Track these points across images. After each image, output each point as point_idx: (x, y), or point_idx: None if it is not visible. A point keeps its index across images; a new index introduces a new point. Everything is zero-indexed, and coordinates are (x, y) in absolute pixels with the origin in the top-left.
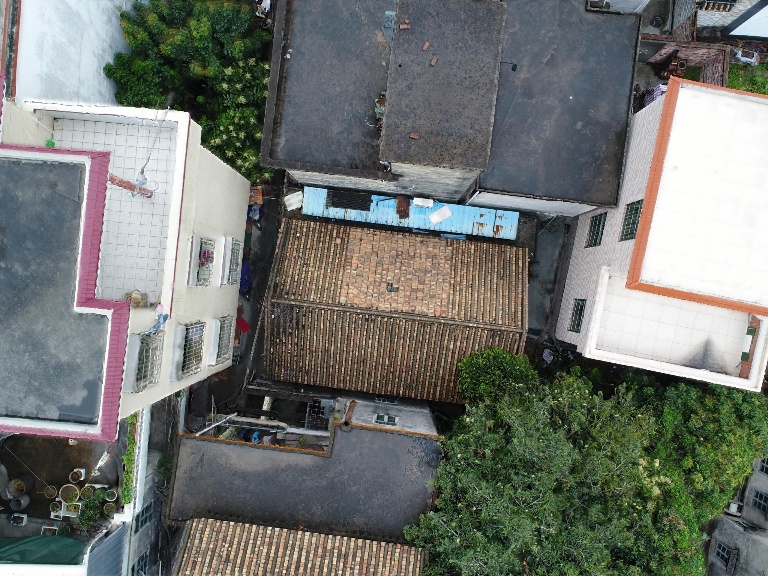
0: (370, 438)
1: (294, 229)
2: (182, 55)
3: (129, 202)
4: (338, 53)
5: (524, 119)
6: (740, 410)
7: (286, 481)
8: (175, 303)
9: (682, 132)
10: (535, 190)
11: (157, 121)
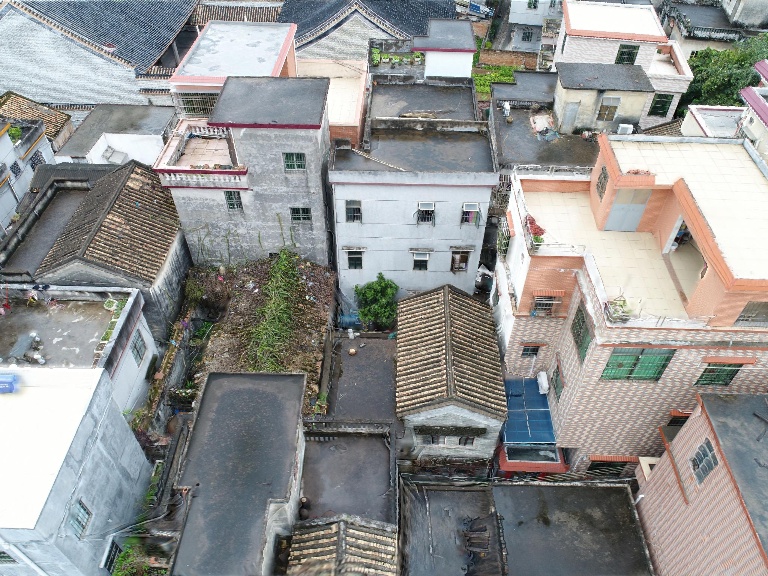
0: None
1: None
2: None
3: None
4: (569, 156)
5: None
6: None
7: None
8: None
9: None
10: None
11: None
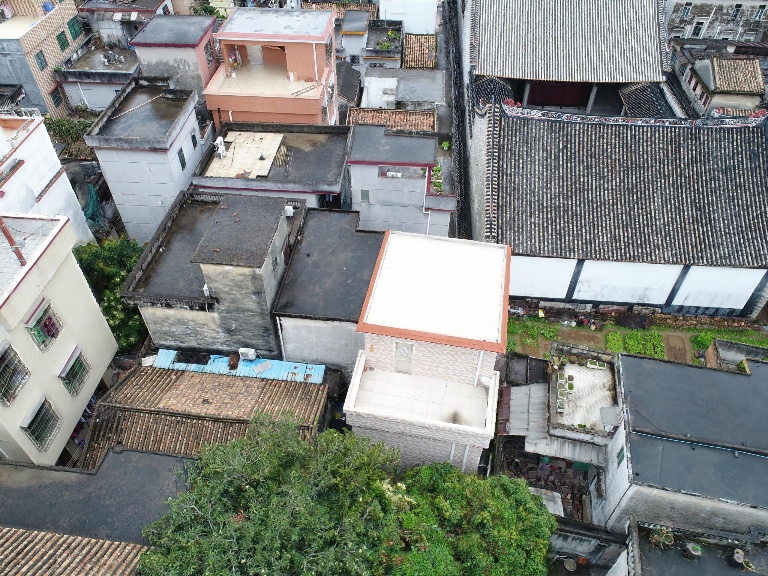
0: (137, 458)
1: (141, 371)
2: (95, 265)
3: (8, 268)
4: None
5: (312, 278)
6: (507, 489)
7: (45, 496)
8: (8, 310)
9: (394, 253)
10: (316, 314)
11: (47, 221)
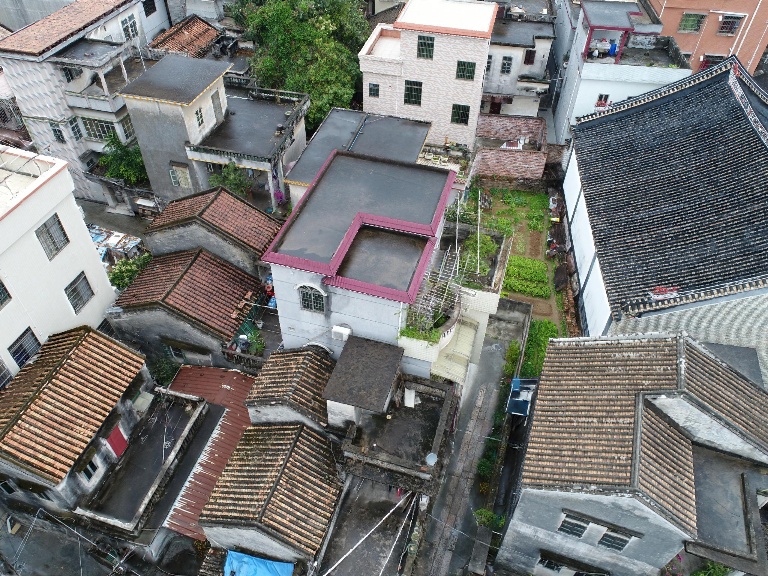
0: None
1: None
2: None
3: None
4: None
5: None
6: None
7: None
8: None
9: None
10: None
11: None
